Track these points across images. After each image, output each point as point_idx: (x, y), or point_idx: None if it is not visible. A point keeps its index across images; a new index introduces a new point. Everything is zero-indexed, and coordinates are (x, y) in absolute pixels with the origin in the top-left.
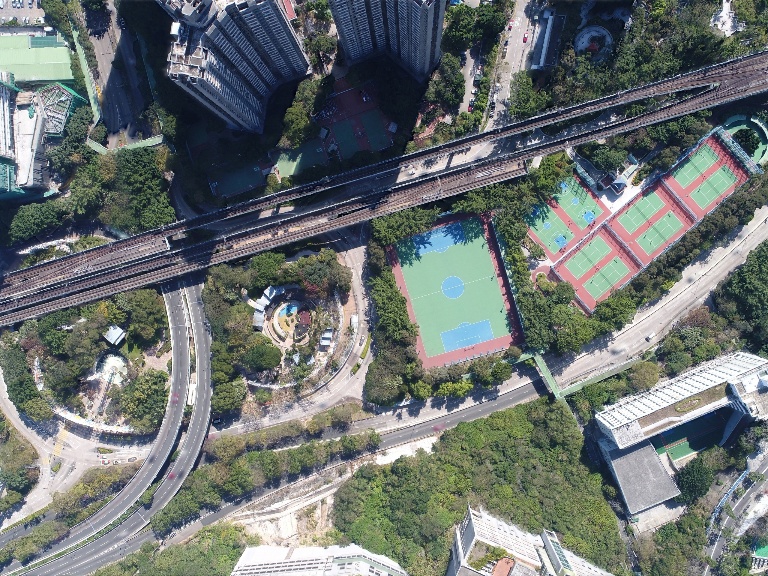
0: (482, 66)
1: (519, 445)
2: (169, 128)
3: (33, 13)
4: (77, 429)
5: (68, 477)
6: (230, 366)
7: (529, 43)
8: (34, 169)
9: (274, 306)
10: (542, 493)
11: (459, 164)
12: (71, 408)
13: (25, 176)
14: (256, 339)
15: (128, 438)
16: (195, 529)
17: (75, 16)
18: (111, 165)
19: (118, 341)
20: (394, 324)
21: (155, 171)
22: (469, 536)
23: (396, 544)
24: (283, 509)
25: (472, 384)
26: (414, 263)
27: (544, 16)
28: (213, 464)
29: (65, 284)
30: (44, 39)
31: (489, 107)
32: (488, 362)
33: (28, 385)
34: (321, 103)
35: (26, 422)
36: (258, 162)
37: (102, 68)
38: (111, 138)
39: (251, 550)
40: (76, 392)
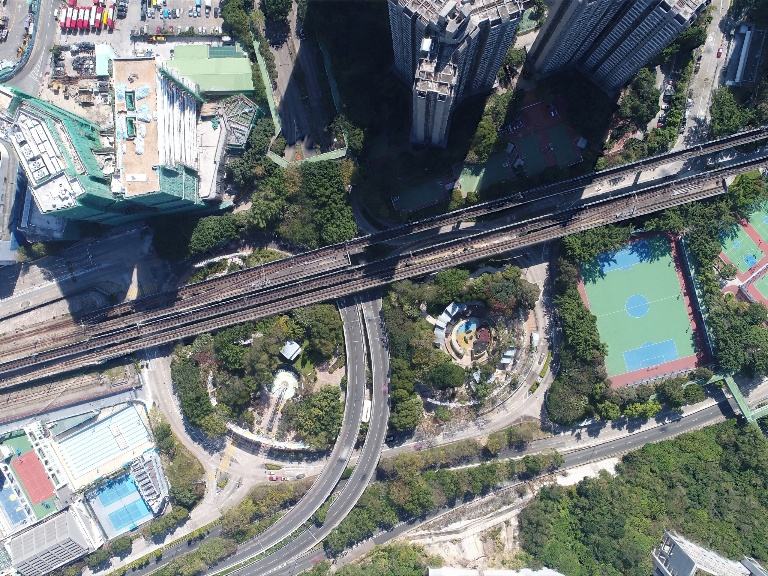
0: (673, 81)
1: (710, 468)
2: (357, 141)
3: (210, 22)
4: (245, 444)
5: (234, 493)
6: (412, 384)
7: (723, 58)
8: (216, 181)
9: (454, 323)
10: (738, 518)
11: (647, 181)
12: (239, 423)
13: (207, 188)
14: (440, 357)
15: (300, 455)
16: (367, 548)
17: (258, 26)
18: (297, 178)
19: (294, 356)
20: (585, 343)
21: (340, 185)
22: (683, 563)
23: (594, 569)
24: (463, 530)
25: (660, 405)
26: (598, 281)
27: (741, 31)
28: (386, 482)
29: (242, 298)
30: (223, 49)
31: (680, 123)
32: (680, 383)
33: (205, 400)
34: (512, 117)
35: (192, 437)
36: (440, 176)
37: (280, 79)
38: (287, 150)
39: (436, 572)
40: (245, 407)
